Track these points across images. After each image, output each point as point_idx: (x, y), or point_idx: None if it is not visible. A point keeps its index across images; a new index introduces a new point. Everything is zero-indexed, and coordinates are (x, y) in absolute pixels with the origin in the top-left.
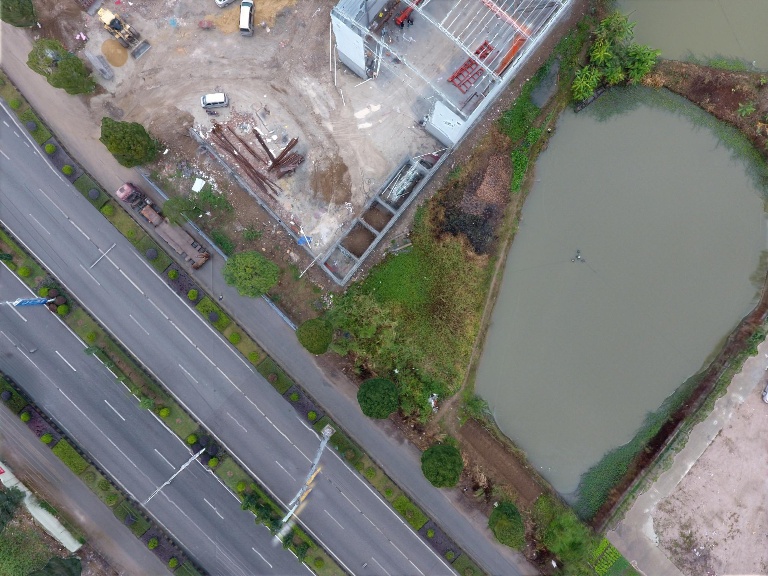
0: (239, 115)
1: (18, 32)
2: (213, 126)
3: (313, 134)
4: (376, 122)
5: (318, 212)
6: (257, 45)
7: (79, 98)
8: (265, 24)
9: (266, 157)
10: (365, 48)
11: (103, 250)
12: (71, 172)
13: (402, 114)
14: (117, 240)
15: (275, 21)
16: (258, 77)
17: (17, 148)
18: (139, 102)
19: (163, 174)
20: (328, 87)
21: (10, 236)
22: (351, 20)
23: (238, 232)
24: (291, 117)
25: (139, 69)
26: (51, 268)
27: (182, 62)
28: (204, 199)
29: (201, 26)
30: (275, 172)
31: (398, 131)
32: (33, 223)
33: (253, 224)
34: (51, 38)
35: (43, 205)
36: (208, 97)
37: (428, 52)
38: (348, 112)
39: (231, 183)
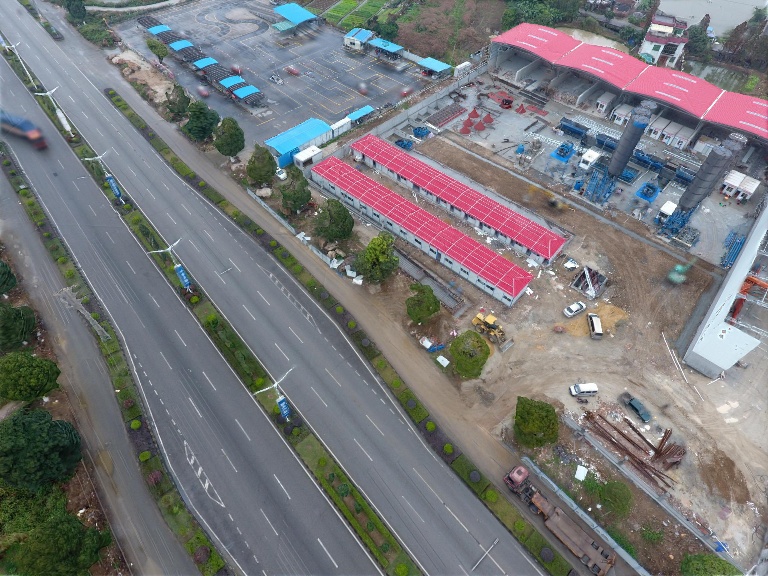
0: (606, 404)
1: (397, 328)
2: (584, 413)
3: (684, 426)
4: (741, 418)
5: (722, 512)
6: (606, 347)
7: (450, 382)
8: (610, 331)
9: (645, 446)
10: (752, 350)
11: (484, 547)
12: (452, 451)
13: (764, 411)
14: (499, 534)
15: (616, 330)
16: (614, 372)
17: (392, 424)
18: (509, 388)
19: (540, 459)
20: (682, 384)
21: (382, 522)
22: (750, 327)
23: (635, 532)
24: (657, 409)
25: (506, 360)
26: (426, 568)
27: (543, 357)
28: (592, 489)
29: (556, 330)
30: (661, 463)
31: (767, 427)
32: (406, 507)
33: (649, 523)
34: (427, 333)
35: (417, 486)
36: (582, 386)
37: (761, 359)
38: (710, 407)
39: (614, 473)
